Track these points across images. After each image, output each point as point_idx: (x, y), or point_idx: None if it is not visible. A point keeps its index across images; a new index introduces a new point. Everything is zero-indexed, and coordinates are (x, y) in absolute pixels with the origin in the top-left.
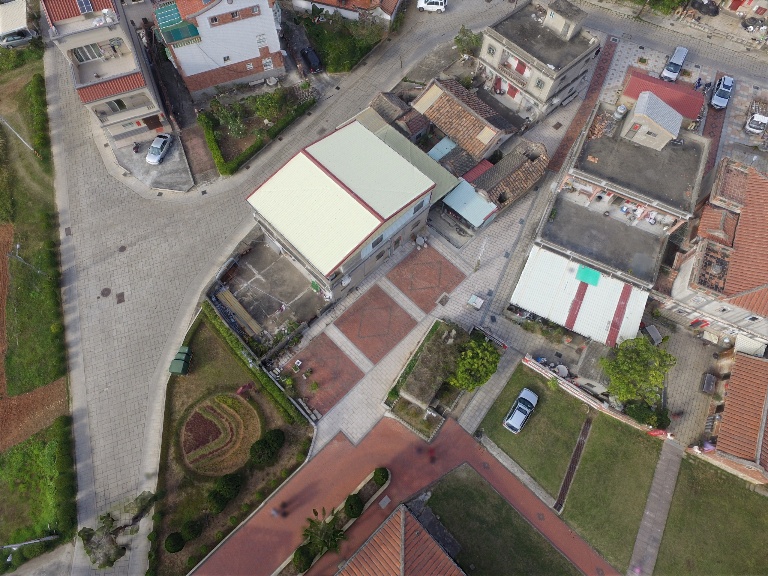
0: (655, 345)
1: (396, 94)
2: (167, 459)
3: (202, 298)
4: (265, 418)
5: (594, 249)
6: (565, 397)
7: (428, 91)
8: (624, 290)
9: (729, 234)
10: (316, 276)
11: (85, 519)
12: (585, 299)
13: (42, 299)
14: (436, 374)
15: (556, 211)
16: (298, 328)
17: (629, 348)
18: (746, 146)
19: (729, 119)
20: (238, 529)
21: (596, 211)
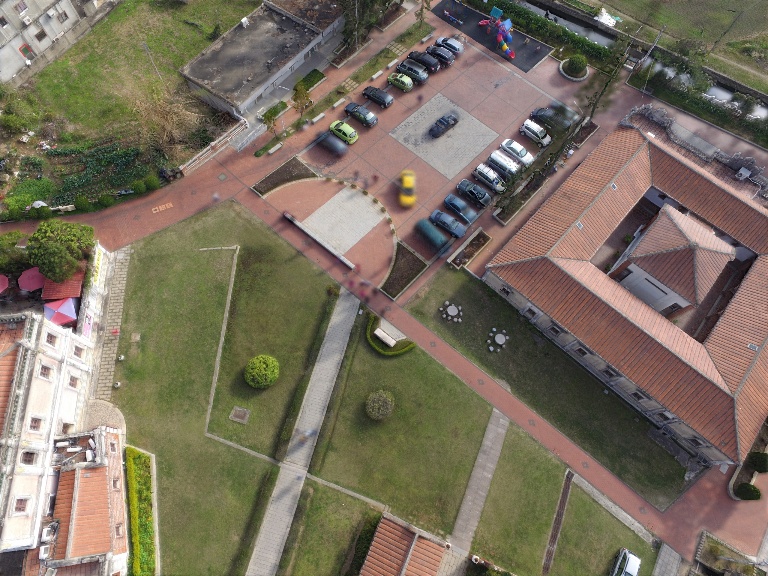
0: None
1: None
2: None
3: None
4: None
5: None
6: None
7: None
8: None
9: None
10: None
11: None
12: None
13: None
14: None
15: None
16: None
17: None
18: None
19: None
20: None
21: None
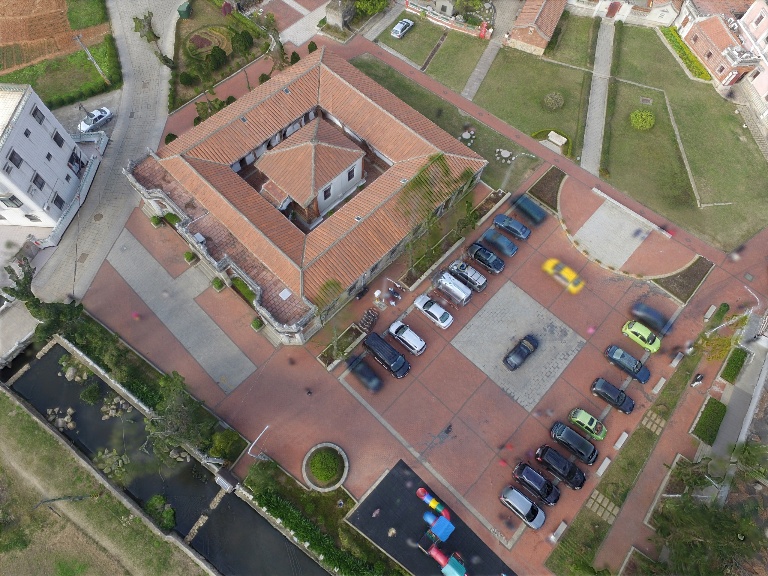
0: None
1: None
2: (178, 55)
3: None
4: None
5: None
6: (431, 24)
7: None
8: None
9: None
10: None
11: (128, 80)
12: None
13: None
14: None
15: None
16: None
17: None
18: None
19: None
20: (225, 81)
21: None
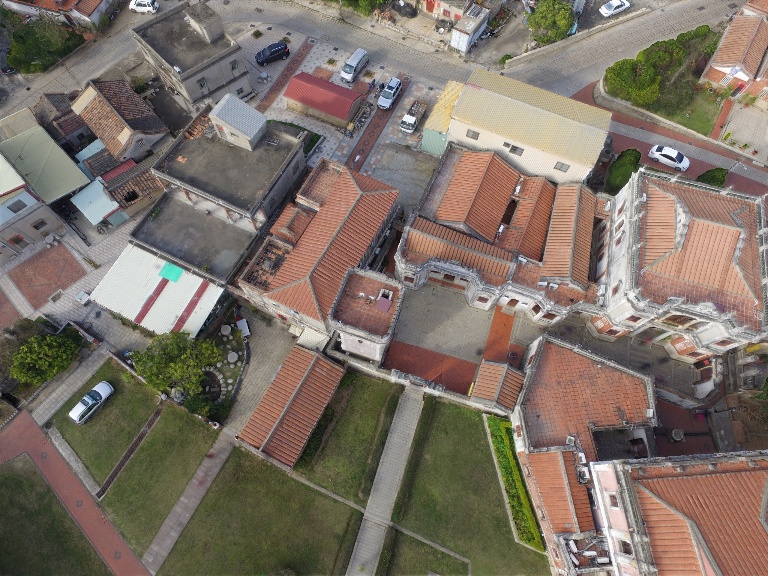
0: (242, 338)
1: (67, 95)
2: None
3: None
4: None
5: (185, 246)
6: (142, 389)
7: (85, 92)
8: (201, 286)
9: (297, 231)
10: None
11: None
12: (161, 295)
13: None
14: None
15: (161, 210)
16: None
17: (162, 341)
18: (400, 145)
19: (393, 119)
20: None
21: (201, 209)
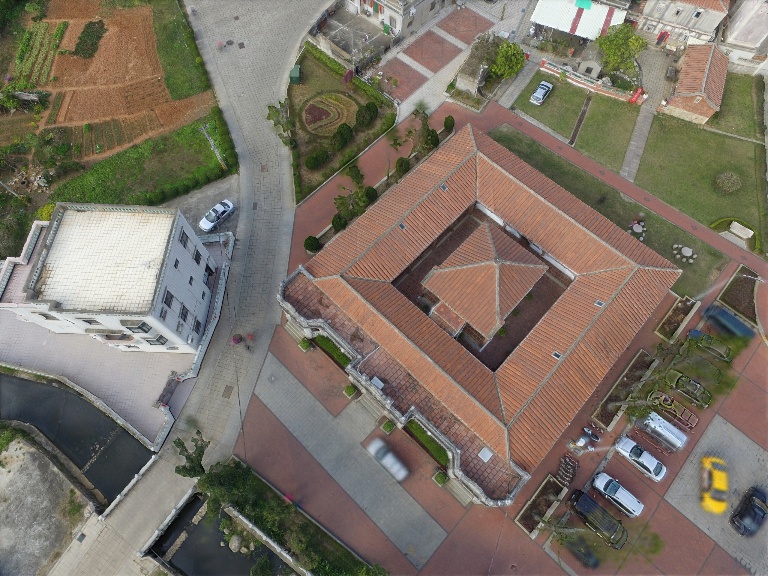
0: None
1: None
2: (295, 129)
3: (302, 43)
4: (361, 105)
5: None
6: (571, 86)
7: None
8: (609, 11)
9: None
10: (391, 8)
11: (244, 162)
12: (582, 17)
13: (183, 47)
14: (482, 60)
15: None
16: (379, 49)
17: (614, 30)
18: None
19: None
20: (352, 162)
21: None
